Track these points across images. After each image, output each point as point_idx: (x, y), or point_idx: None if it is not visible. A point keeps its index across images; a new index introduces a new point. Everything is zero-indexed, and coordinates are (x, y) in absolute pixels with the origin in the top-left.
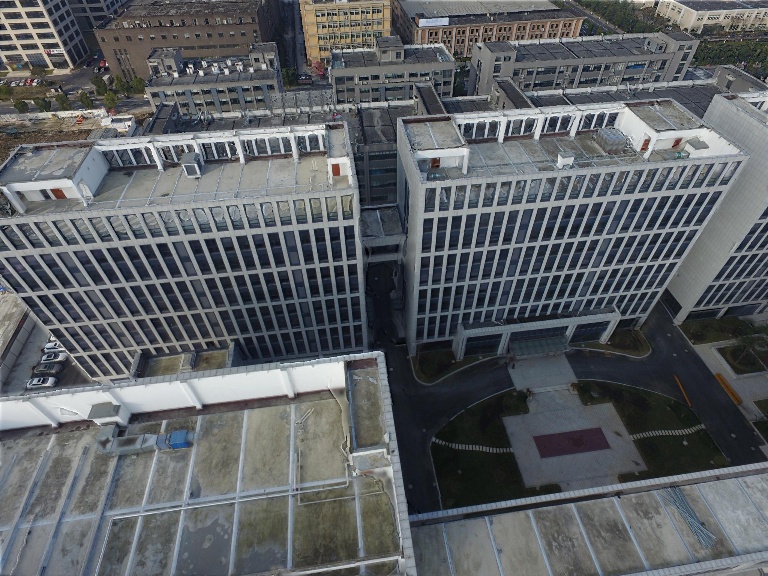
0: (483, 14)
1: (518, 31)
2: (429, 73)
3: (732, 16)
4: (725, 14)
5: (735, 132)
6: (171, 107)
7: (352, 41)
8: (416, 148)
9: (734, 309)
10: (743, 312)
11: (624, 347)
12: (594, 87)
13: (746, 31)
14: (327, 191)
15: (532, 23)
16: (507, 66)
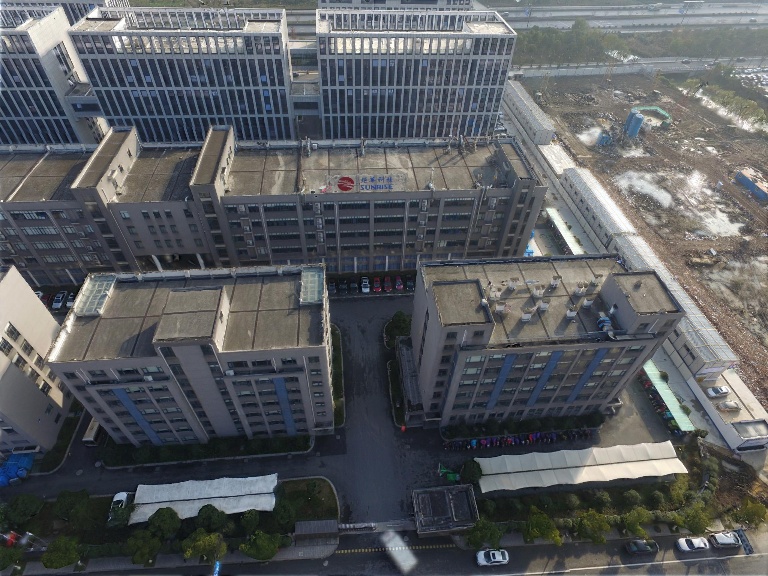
0: None
1: None
2: None
3: None
4: None
5: (49, 35)
6: (520, 175)
7: None
8: (278, 22)
9: None
10: None
11: None
12: None
13: None
14: (332, 9)
15: None
16: None
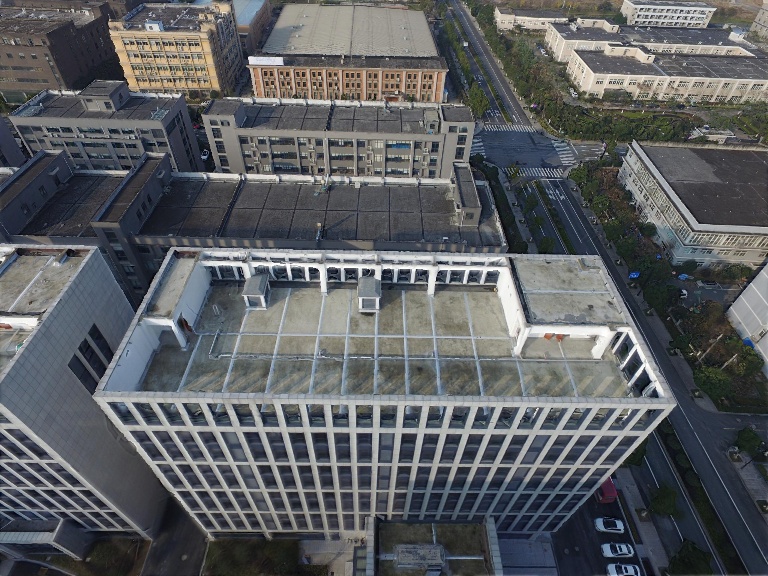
0: (337, 55)
1: (369, 78)
2: (134, 131)
3: (638, 82)
4: (630, 79)
5: None
6: None
7: (172, 74)
8: None
9: (283, 534)
10: (307, 536)
11: (100, 571)
12: (283, 175)
13: (658, 101)
14: None
15: (384, 71)
16: (229, 131)
